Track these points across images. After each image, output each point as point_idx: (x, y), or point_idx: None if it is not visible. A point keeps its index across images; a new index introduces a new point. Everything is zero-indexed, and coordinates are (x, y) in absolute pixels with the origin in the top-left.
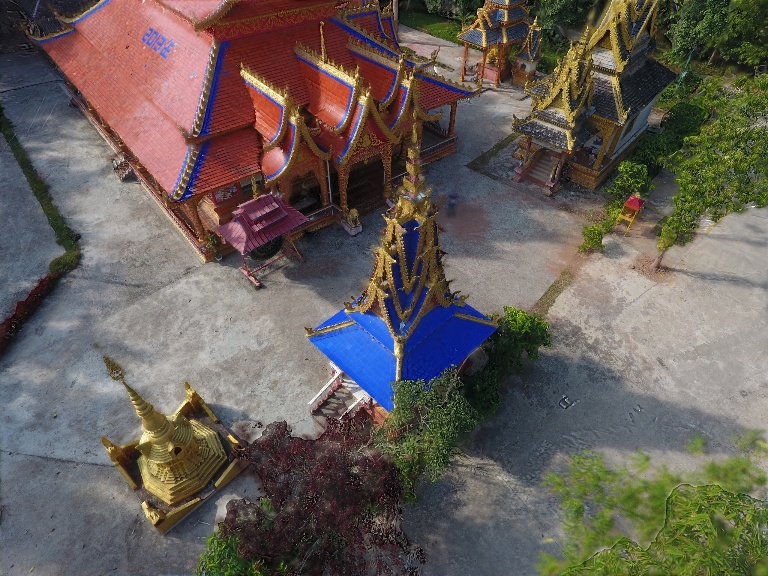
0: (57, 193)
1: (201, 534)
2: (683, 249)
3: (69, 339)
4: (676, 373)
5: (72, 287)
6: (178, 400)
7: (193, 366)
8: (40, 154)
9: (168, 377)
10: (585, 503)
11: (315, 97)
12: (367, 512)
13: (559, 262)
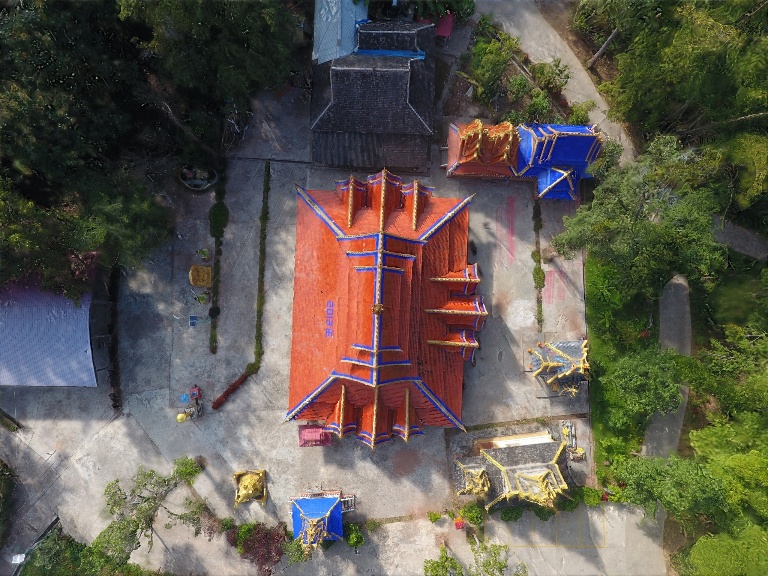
0: (266, 310)
1: (246, 506)
2: (466, 544)
3: (241, 413)
4: (396, 572)
5: (250, 385)
6: (259, 463)
7: (269, 454)
8: (271, 264)
9: (261, 453)
10: (332, 574)
11: (369, 407)
12: (267, 565)
13: (415, 510)
